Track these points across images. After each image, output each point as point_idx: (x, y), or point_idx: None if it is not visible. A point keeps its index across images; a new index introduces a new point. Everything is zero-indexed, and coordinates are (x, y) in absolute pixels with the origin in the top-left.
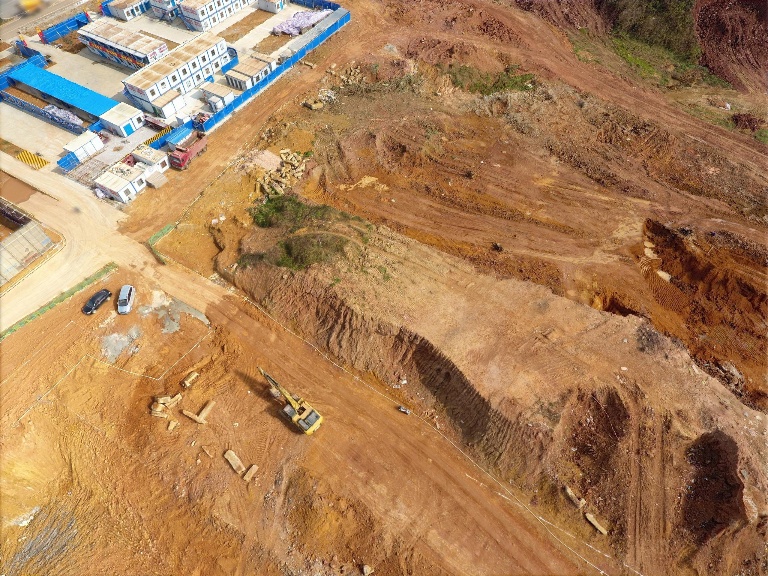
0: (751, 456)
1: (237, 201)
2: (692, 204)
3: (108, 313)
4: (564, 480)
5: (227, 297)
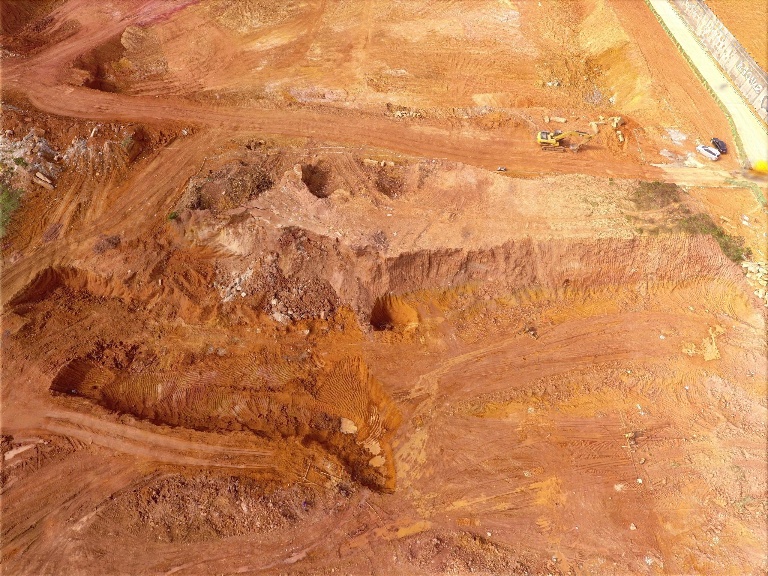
0: (298, 193)
1: (760, 242)
2: (337, 575)
3: (705, 145)
4: (396, 168)
5: (663, 180)
